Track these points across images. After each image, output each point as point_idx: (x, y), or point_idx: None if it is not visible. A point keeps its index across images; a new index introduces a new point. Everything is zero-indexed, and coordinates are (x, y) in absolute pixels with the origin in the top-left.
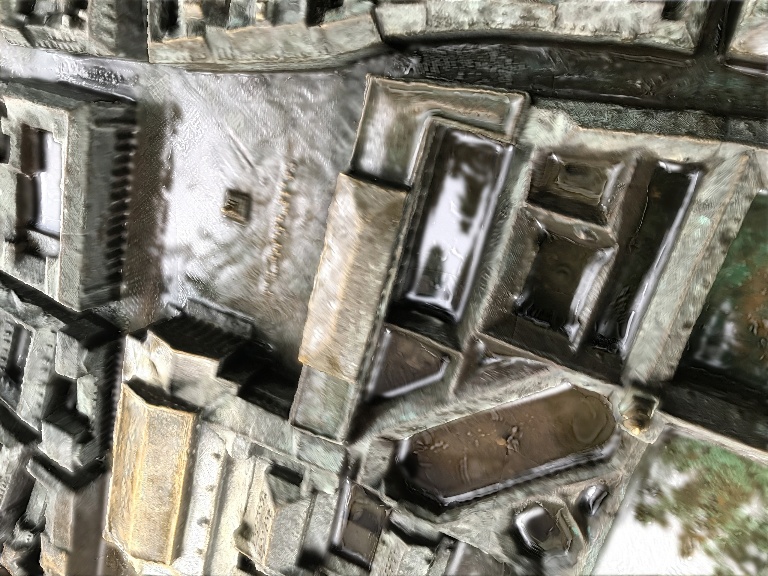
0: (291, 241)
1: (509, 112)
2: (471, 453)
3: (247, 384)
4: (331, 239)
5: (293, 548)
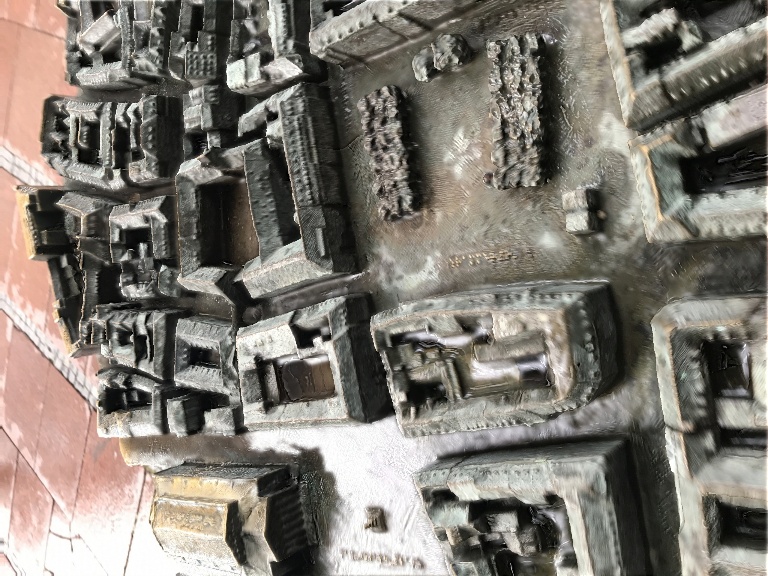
0: (377, 571)
1: None
2: None
3: None
4: None
5: None
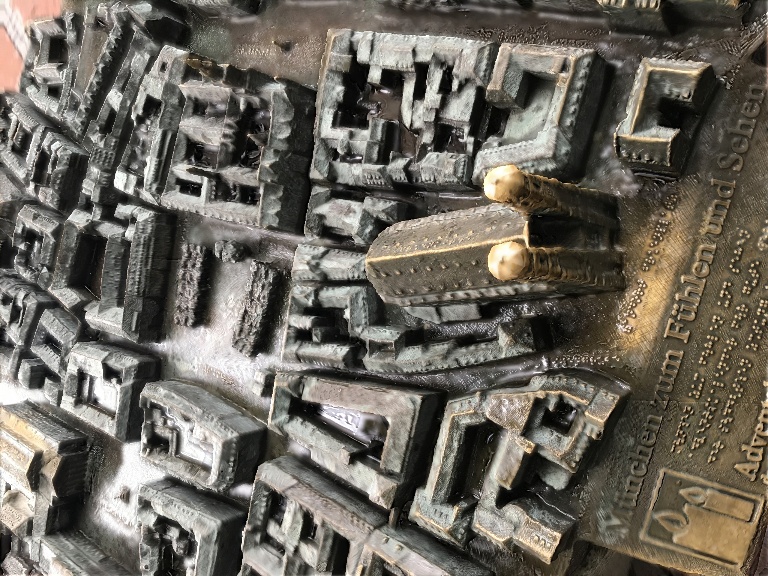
0: (117, 524)
1: None
2: None
3: (57, 506)
4: None
5: None
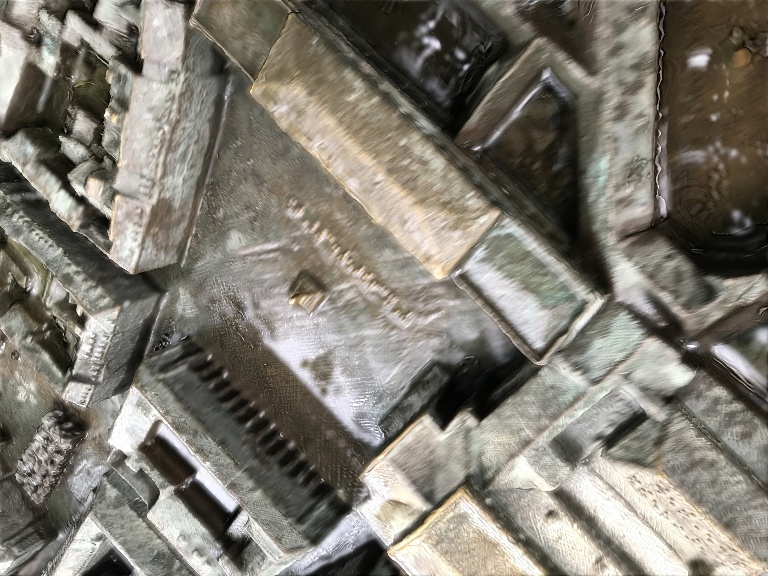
0: (362, 250)
1: None
2: (752, 130)
3: (478, 403)
4: (308, 141)
5: (760, 504)
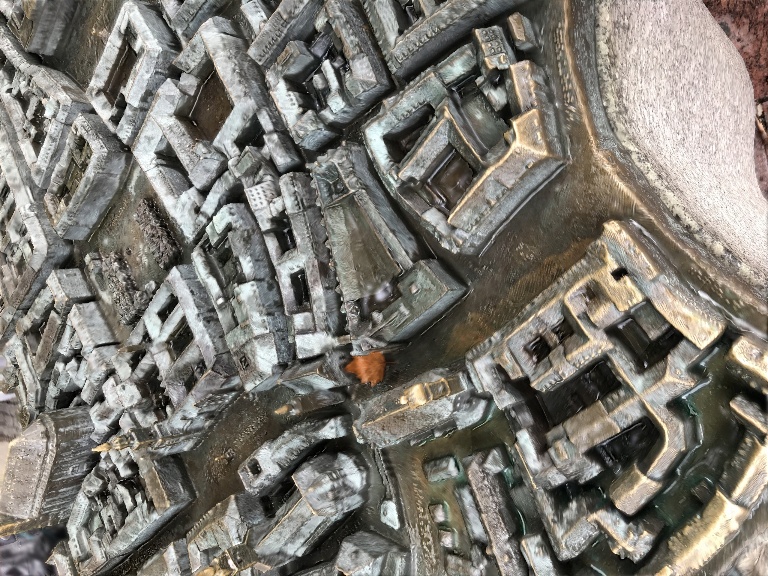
0: (96, 11)
1: (9, 21)
2: None
3: None
4: None
5: None
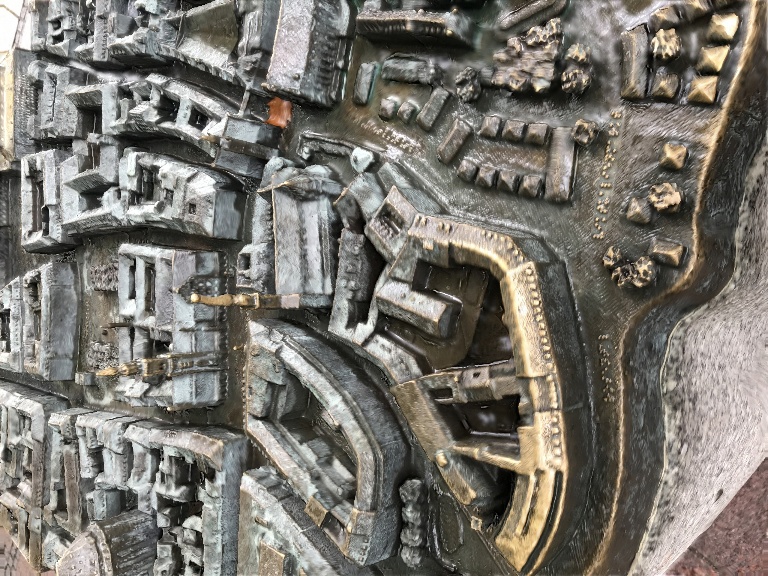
0: None
1: None
2: None
3: None
4: None
5: None
